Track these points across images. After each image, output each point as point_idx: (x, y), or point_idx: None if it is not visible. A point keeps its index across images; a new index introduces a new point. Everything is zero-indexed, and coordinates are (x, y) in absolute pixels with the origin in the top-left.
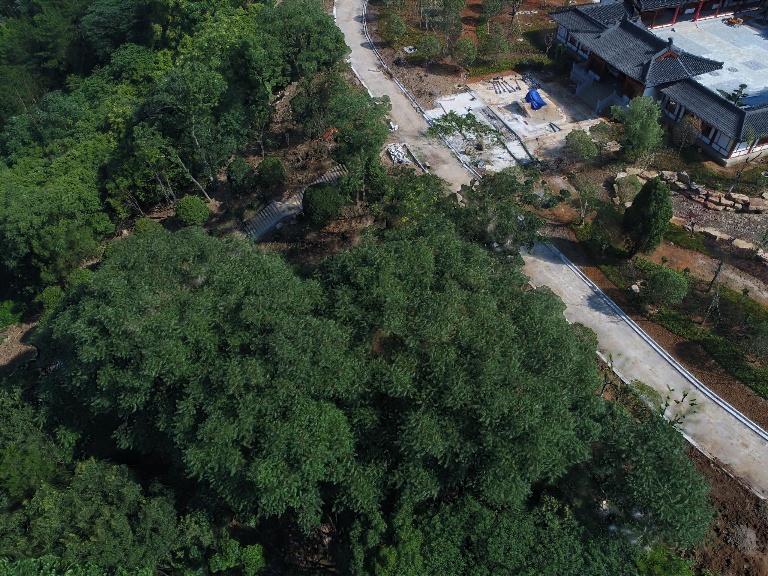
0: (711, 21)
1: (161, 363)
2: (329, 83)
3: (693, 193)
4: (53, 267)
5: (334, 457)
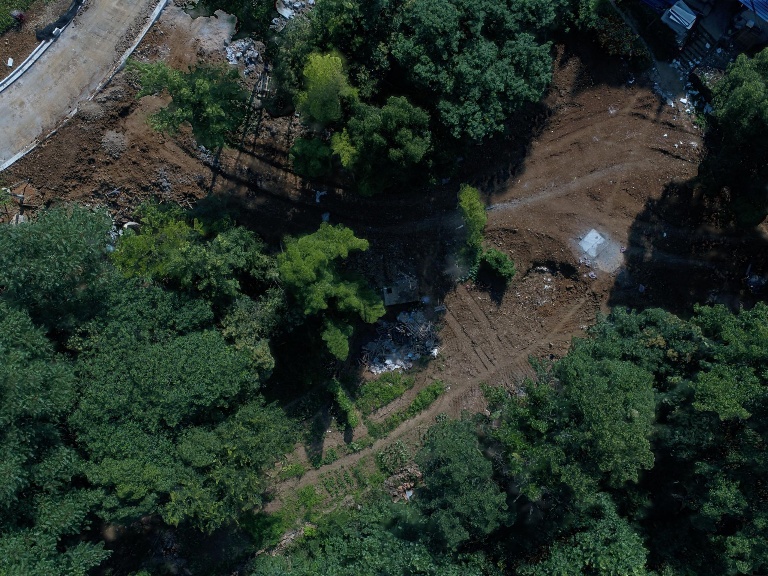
0: None
1: None
2: None
3: None
4: None
5: (30, 552)
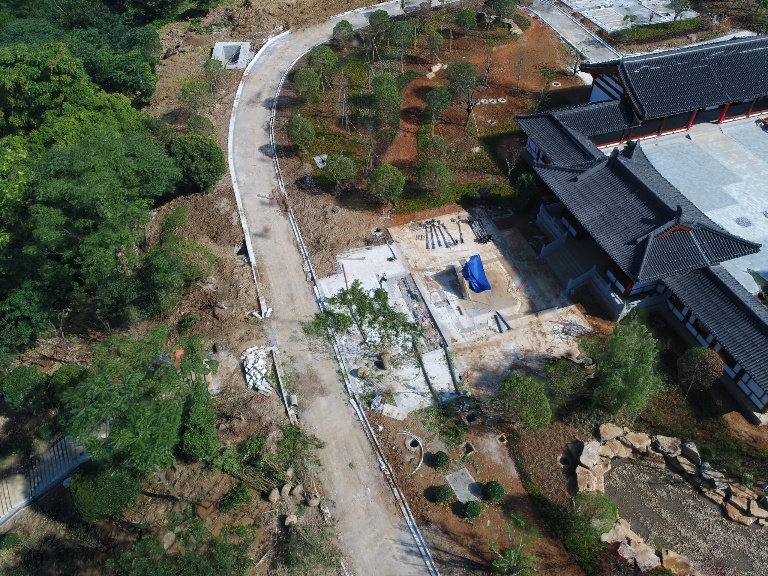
0: (741, 123)
1: None
2: None
3: (705, 484)
4: None
5: None
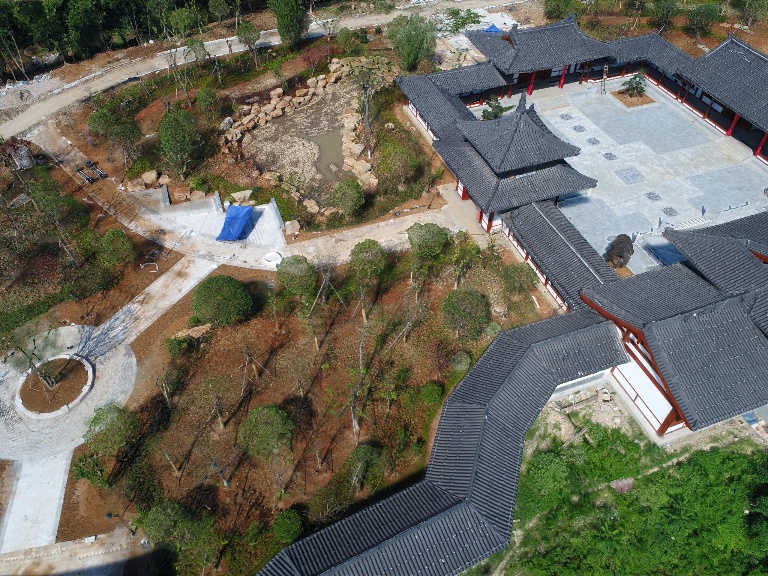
0: None
1: None
2: None
3: None
4: None
5: None
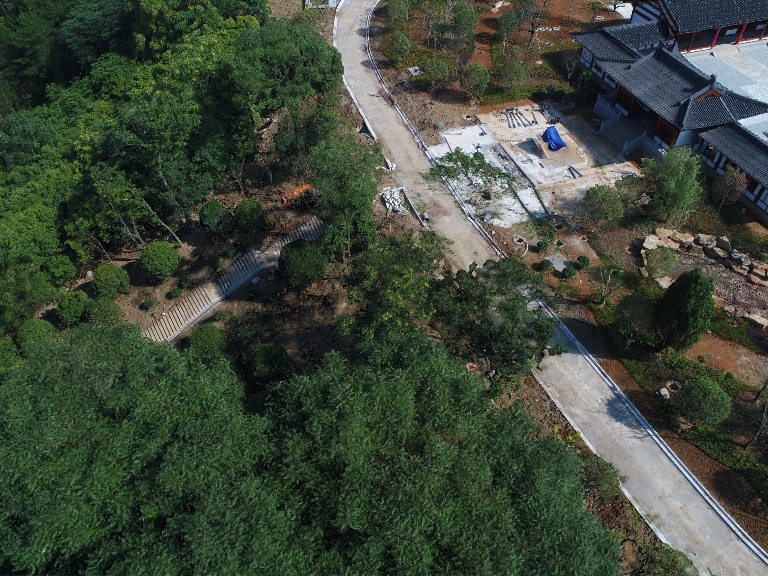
0: (755, 44)
1: (55, 535)
2: (317, 118)
3: (734, 263)
4: (1, 319)
5: None
